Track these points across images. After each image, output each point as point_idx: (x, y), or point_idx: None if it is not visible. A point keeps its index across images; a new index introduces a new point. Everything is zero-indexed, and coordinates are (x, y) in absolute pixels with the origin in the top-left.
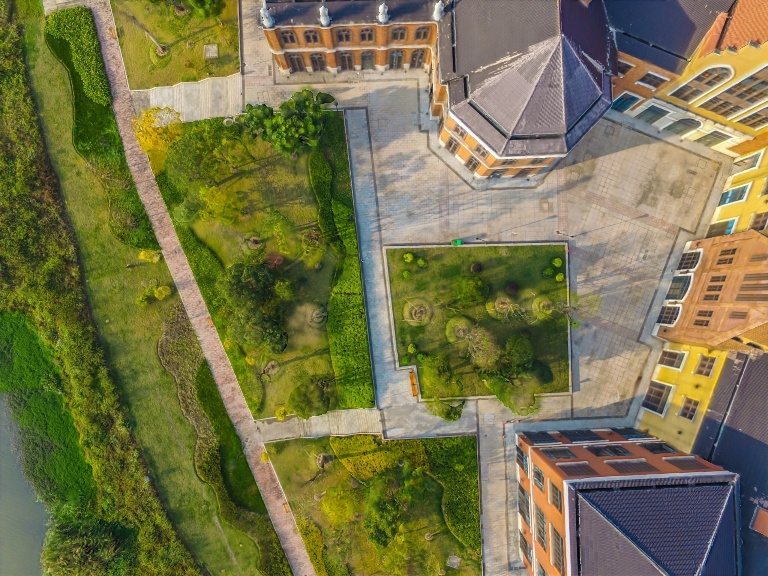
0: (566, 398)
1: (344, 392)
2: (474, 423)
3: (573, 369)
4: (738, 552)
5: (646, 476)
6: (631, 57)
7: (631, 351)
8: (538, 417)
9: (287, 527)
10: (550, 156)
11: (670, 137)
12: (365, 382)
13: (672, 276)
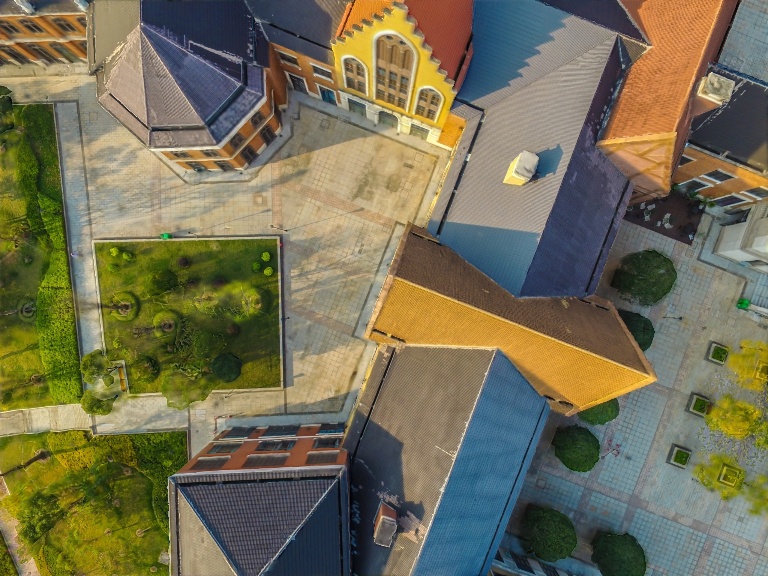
0: (279, 393)
1: (53, 387)
2: (186, 418)
3: (286, 364)
4: (343, 547)
5: (255, 470)
6: (285, 48)
7: (346, 346)
8: (251, 412)
9: (11, 524)
10: (203, 148)
11: (386, 130)
12: (71, 377)
13: (387, 270)
